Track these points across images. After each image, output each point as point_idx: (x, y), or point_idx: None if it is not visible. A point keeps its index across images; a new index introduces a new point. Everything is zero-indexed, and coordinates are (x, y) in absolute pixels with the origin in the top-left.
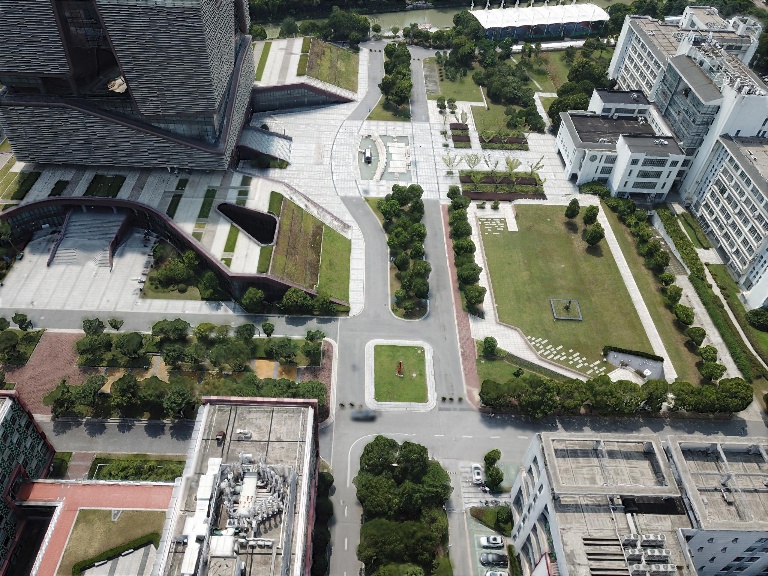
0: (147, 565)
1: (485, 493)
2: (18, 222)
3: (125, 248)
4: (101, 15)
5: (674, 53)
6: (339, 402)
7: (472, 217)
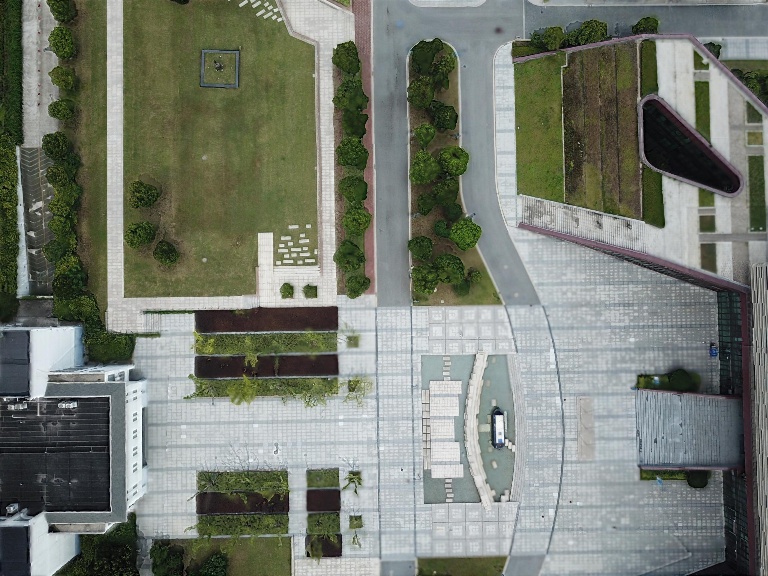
0: None
1: None
2: None
3: None
4: None
5: None
6: None
7: (328, 264)
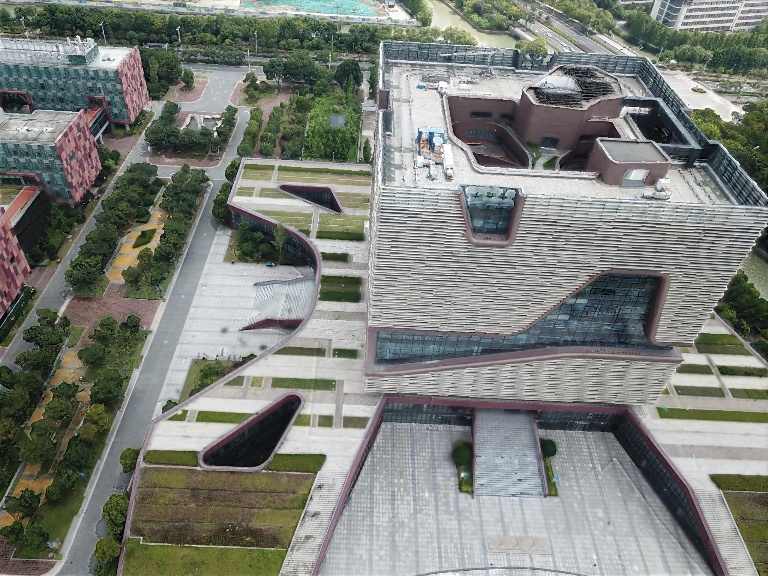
0: None
1: None
2: (302, 248)
3: (276, 335)
4: None
5: None
6: None
7: None
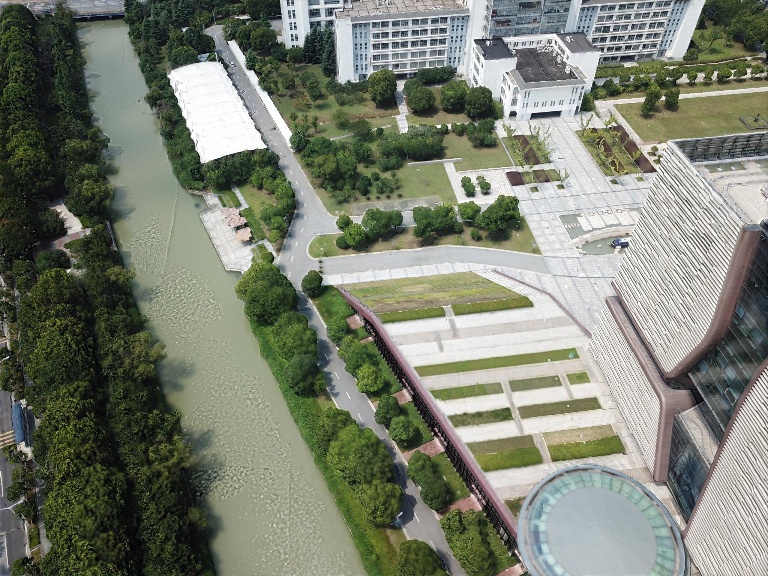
0: None
1: None
2: None
3: None
4: None
5: (423, 8)
6: None
7: None
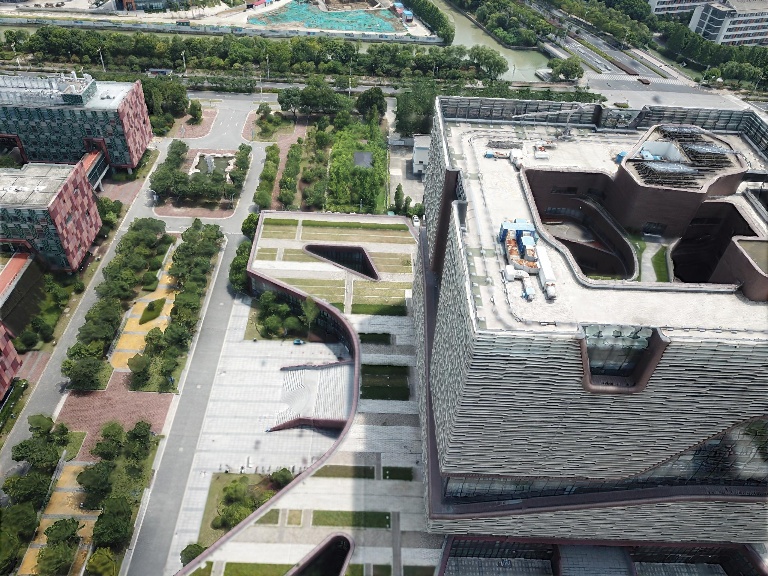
0: None
1: None
2: (335, 323)
3: (310, 437)
4: (447, 242)
5: None
6: None
7: None
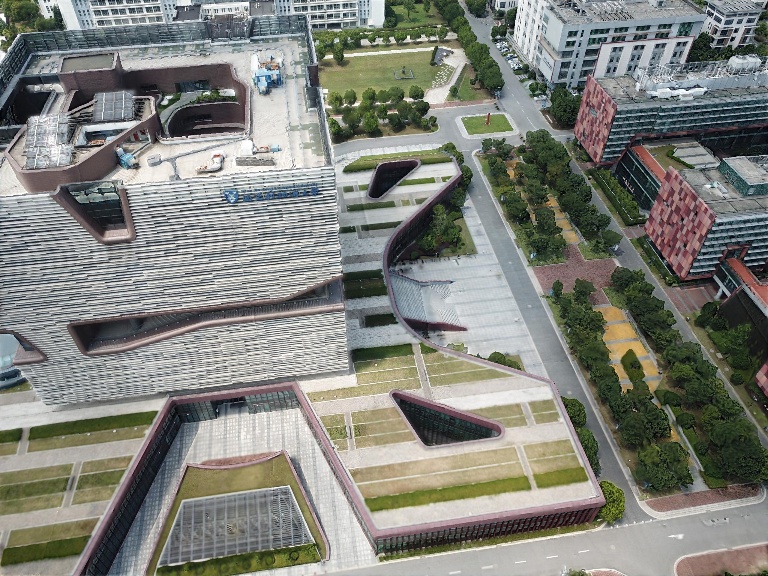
0: (682, 155)
1: (548, 97)
2: None
3: None
4: None
5: None
6: (521, 143)
7: None
